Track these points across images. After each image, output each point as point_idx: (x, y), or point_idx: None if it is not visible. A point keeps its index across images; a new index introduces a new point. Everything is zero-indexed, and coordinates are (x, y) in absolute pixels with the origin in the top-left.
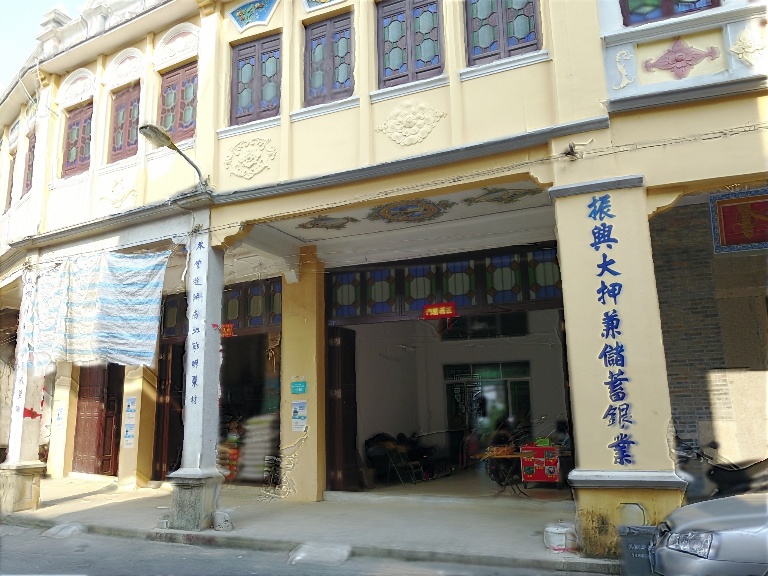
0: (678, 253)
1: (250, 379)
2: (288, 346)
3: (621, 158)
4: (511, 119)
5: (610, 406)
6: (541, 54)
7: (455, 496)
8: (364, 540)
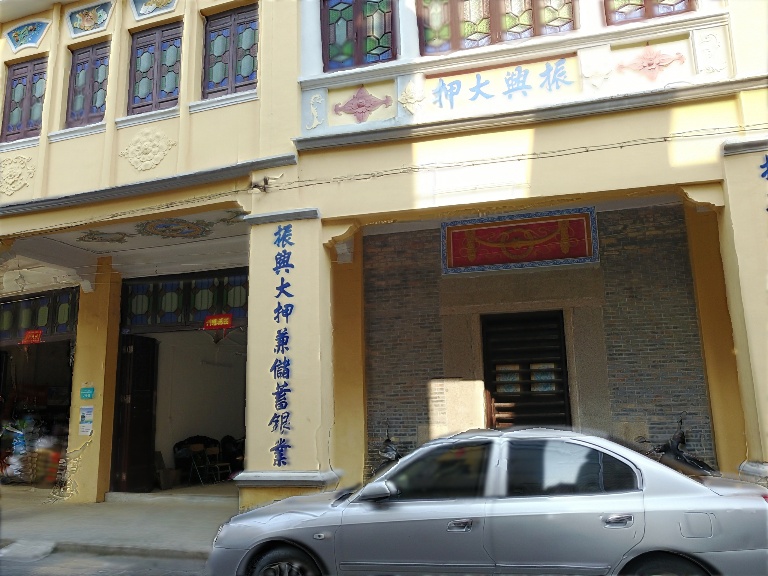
0: (413, 273)
1: (53, 384)
2: (81, 353)
3: (305, 192)
4: (227, 151)
5: (275, 414)
6: (253, 93)
7: (224, 496)
8: (80, 538)
